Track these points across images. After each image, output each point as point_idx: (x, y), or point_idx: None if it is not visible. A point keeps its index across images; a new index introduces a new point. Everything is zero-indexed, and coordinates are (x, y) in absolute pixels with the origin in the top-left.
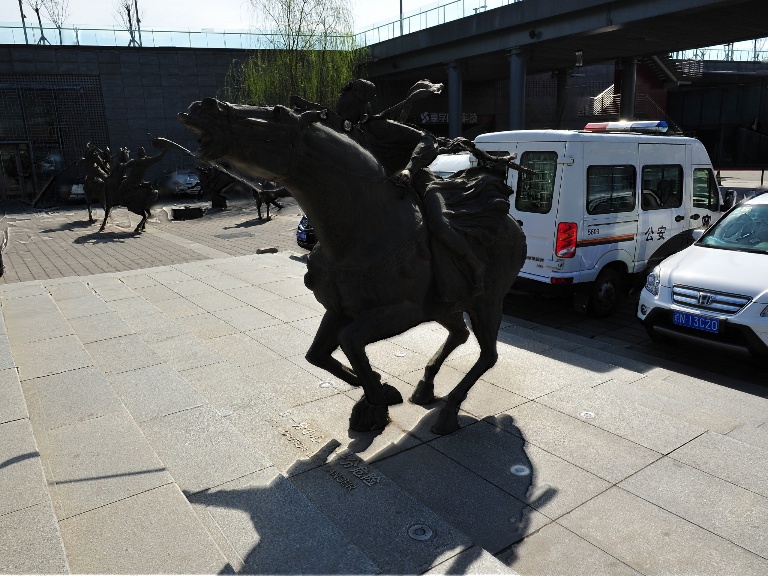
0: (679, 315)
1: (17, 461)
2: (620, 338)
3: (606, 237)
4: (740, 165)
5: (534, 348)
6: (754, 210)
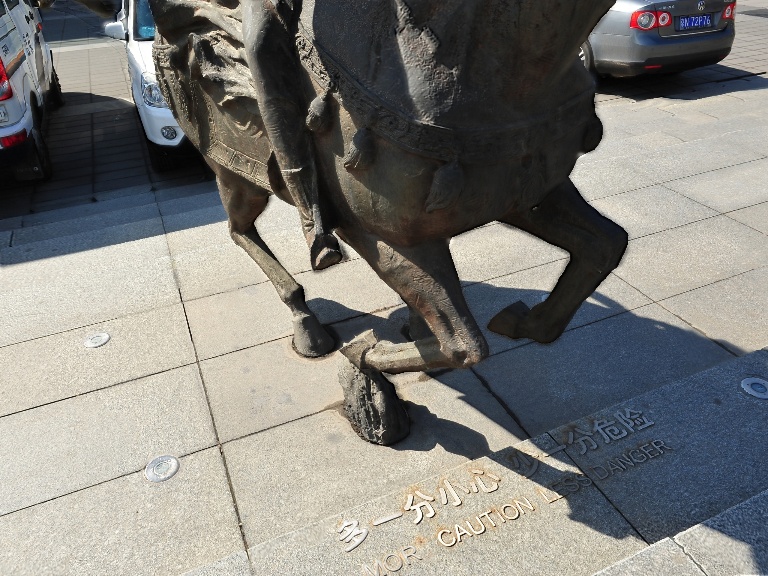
0: None
1: None
2: (123, 186)
3: (15, 56)
4: None
5: (147, 230)
6: None
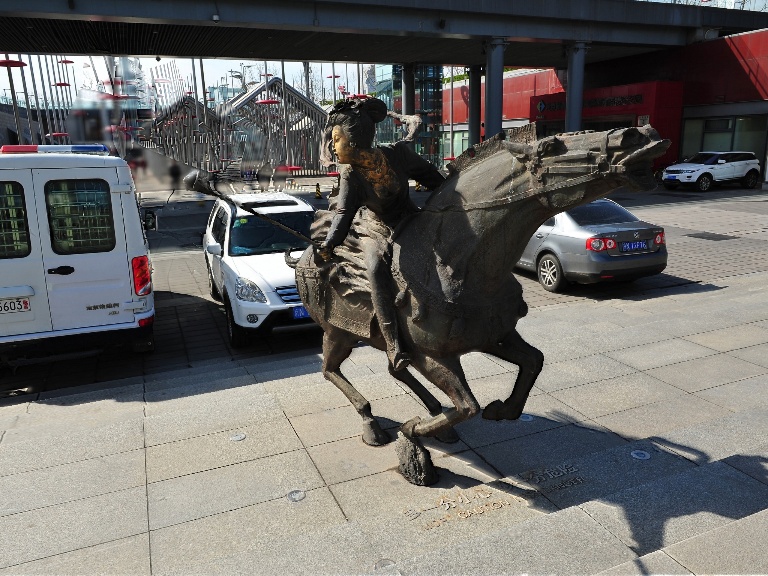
0: (299, 310)
1: None
2: (211, 357)
3: (150, 266)
4: (157, 186)
5: (245, 382)
6: (250, 221)
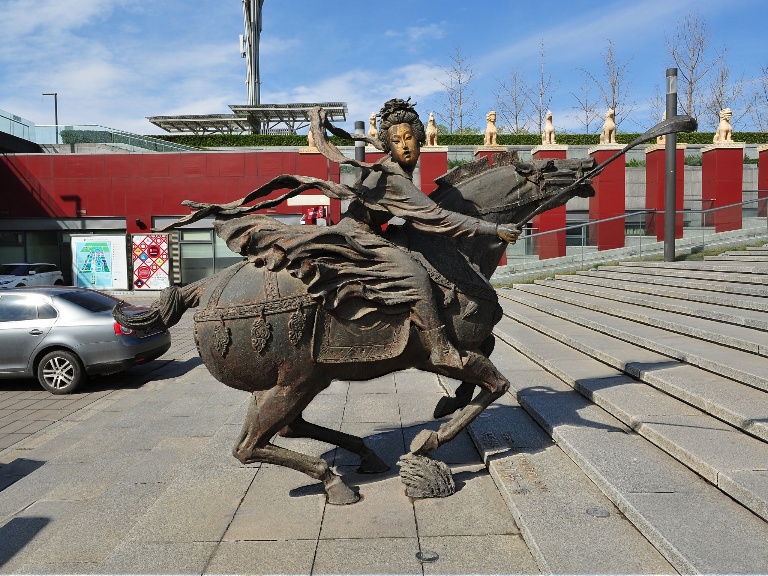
0: None
1: (766, 419)
2: None
3: None
4: None
5: None
6: None
